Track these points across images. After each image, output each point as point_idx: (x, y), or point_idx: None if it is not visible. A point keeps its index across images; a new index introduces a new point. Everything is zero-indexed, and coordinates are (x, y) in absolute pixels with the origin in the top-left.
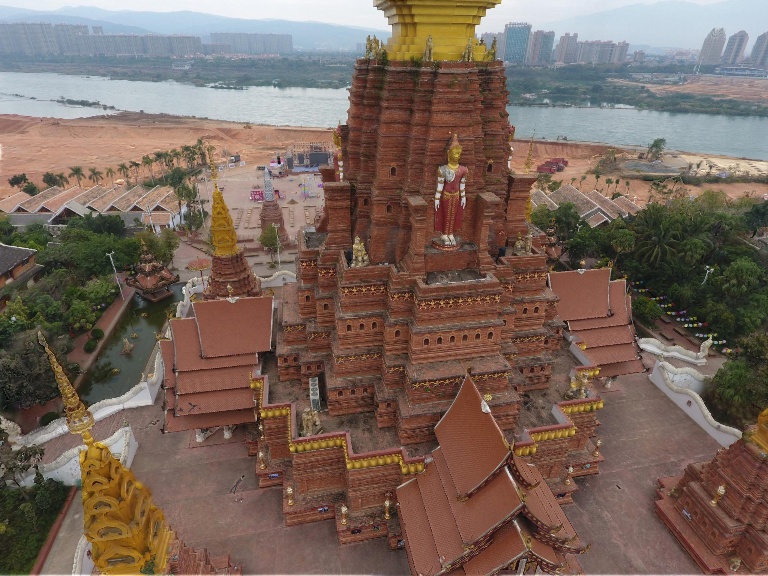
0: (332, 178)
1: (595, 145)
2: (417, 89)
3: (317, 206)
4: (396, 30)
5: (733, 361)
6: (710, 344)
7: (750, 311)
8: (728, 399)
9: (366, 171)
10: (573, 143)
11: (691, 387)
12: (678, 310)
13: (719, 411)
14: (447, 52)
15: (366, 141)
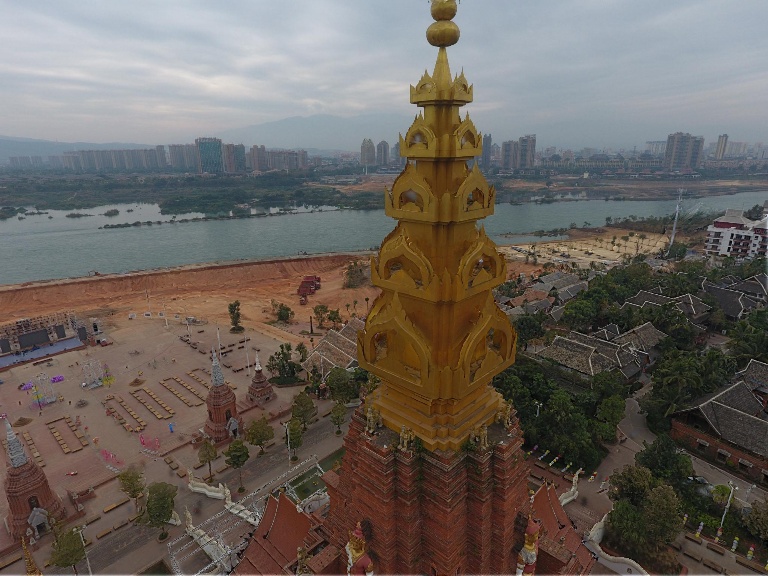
0: (331, 572)
1: (333, 256)
2: (478, 480)
3: (67, 417)
4: (409, 399)
5: (616, 501)
6: (577, 478)
7: (581, 433)
8: (635, 542)
9: (413, 575)
10: (314, 257)
11: (599, 536)
12: (529, 445)
13: (629, 552)
14: (480, 418)
15: (413, 545)
